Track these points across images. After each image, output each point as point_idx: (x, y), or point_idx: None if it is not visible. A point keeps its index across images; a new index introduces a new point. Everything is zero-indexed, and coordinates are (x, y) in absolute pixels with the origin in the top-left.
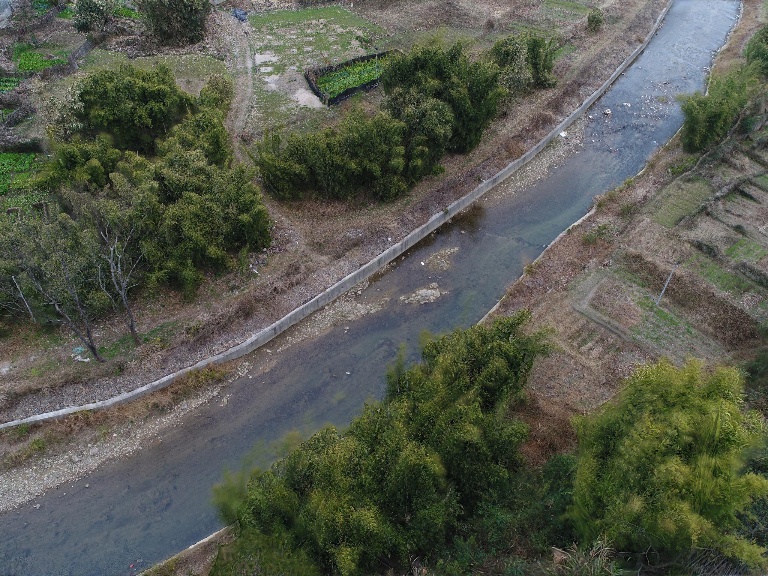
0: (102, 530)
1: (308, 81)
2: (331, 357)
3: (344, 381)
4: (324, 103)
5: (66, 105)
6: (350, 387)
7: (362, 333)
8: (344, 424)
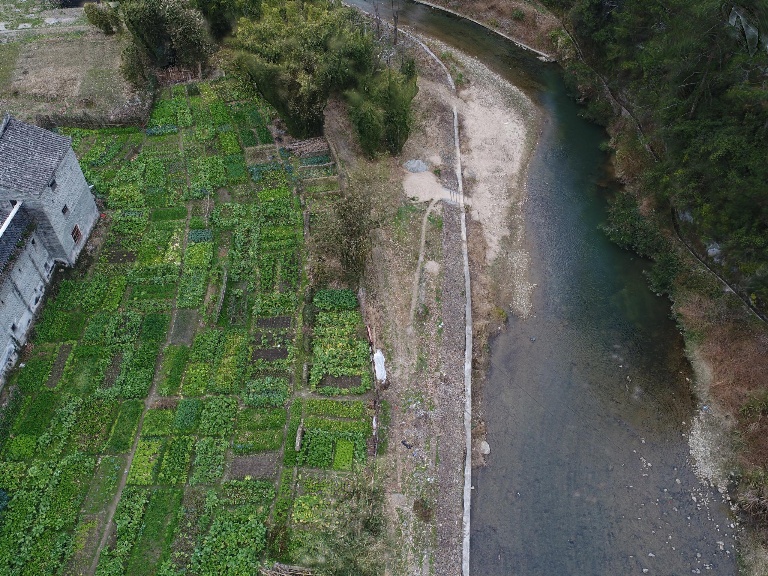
0: (480, 43)
1: (68, 6)
2: (372, 8)
3: (387, 5)
4: (114, 0)
5: (179, 6)
6: (390, 4)
7: (355, 3)
8: (411, 5)
